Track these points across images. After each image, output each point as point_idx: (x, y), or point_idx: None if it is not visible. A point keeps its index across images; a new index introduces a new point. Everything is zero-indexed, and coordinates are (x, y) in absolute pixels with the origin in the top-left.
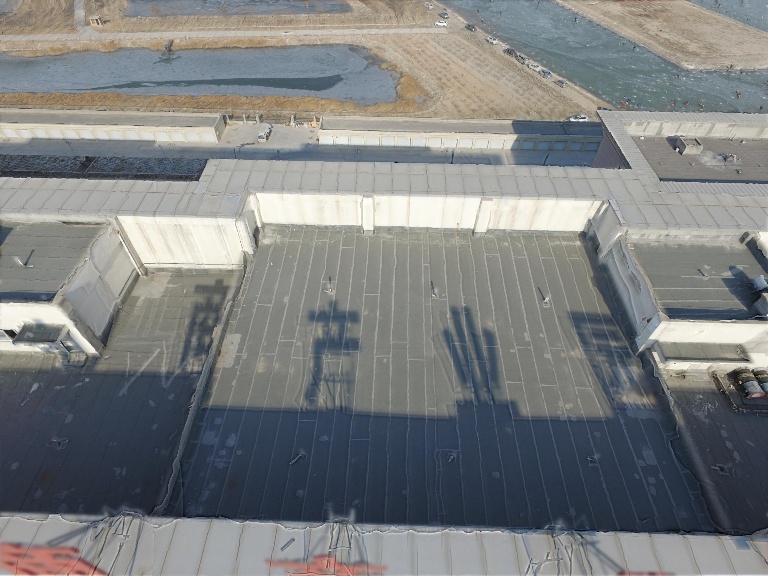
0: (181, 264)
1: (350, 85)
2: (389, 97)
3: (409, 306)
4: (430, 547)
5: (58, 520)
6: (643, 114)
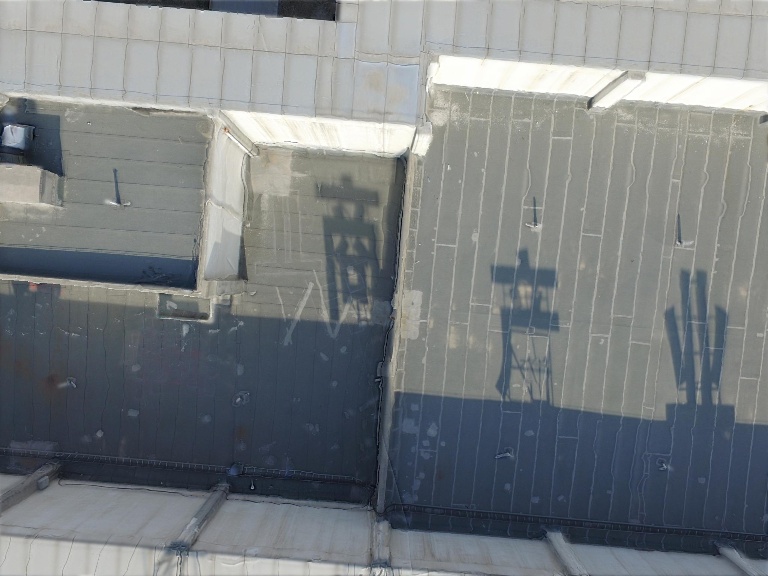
0: (307, 144)
1: None
2: None
3: (642, 259)
4: None
5: (321, 561)
6: None
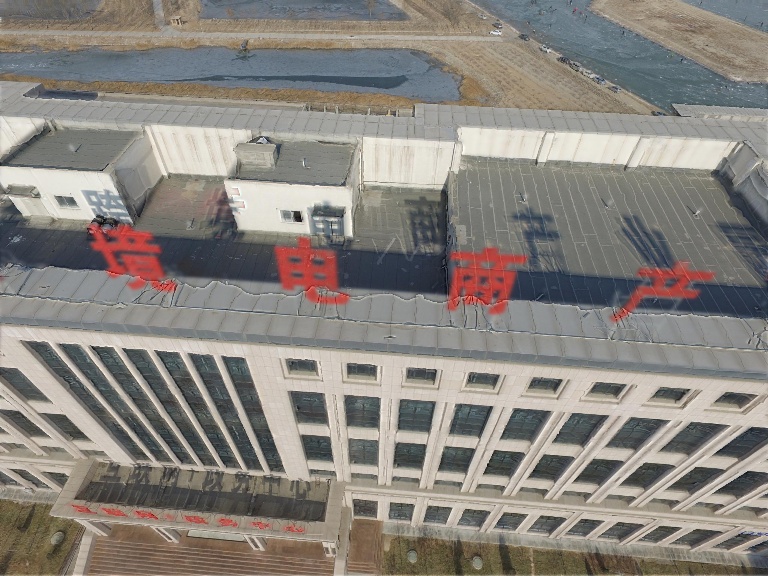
0: (392, 183)
1: (415, 85)
2: (453, 96)
3: (589, 213)
4: (683, 321)
5: None
6: (714, 108)
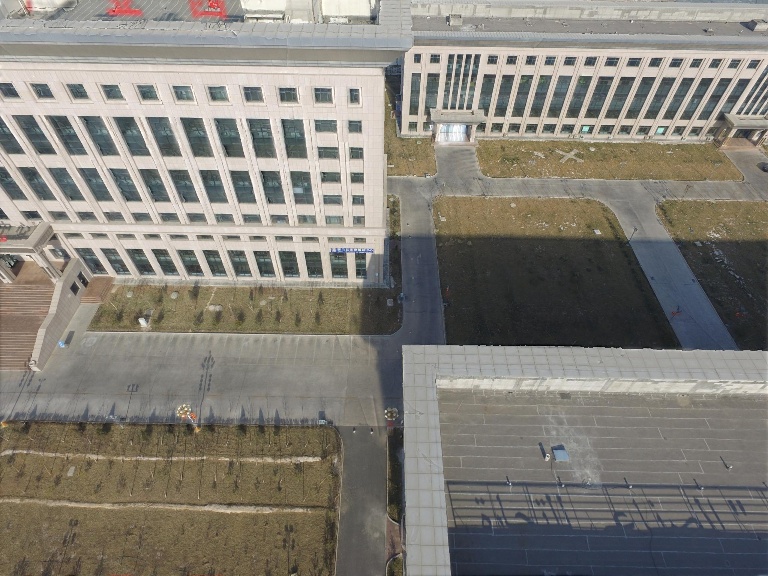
0: (47, 8)
1: None
2: None
3: (150, 12)
4: None
5: None
6: None
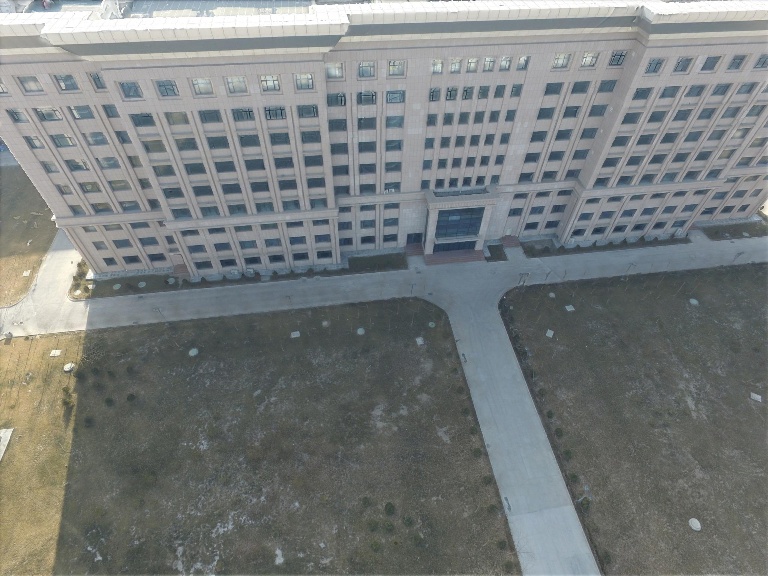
0: None
1: None
2: None
3: None
4: None
5: None
6: None
